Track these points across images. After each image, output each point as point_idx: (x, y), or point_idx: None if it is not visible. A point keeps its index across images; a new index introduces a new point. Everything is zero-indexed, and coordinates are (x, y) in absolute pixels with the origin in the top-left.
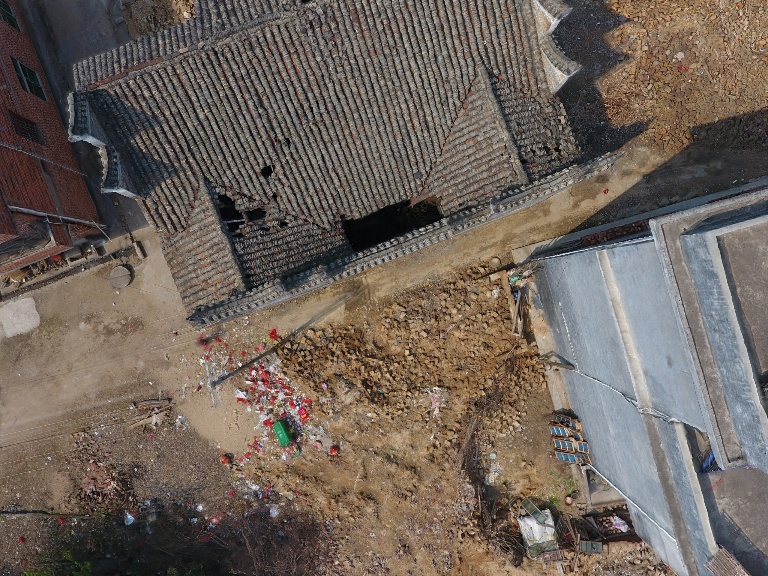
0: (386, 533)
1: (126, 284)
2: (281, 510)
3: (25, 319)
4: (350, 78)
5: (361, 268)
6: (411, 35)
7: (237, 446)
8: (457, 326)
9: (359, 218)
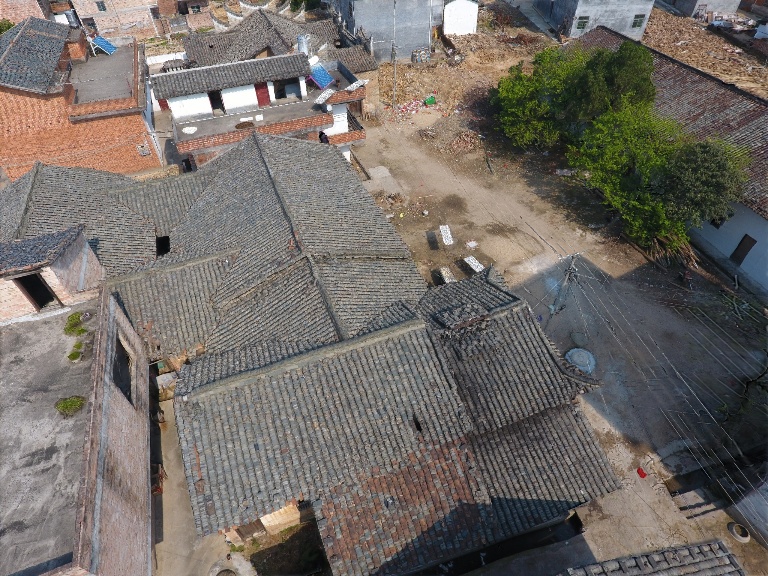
0: None
1: None
2: None
3: (380, 170)
4: None
5: None
6: None
7: None
8: None
9: None
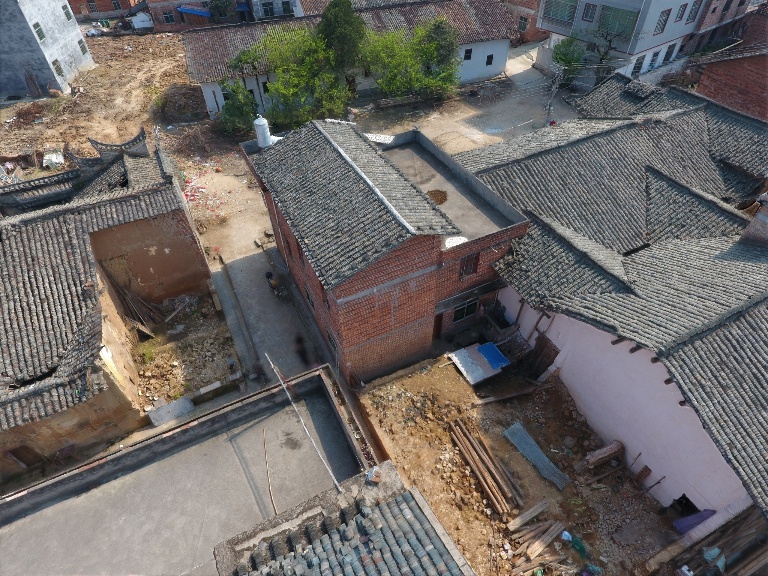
0: None
1: (269, 227)
2: None
3: None
4: None
5: None
6: None
7: None
8: None
9: None
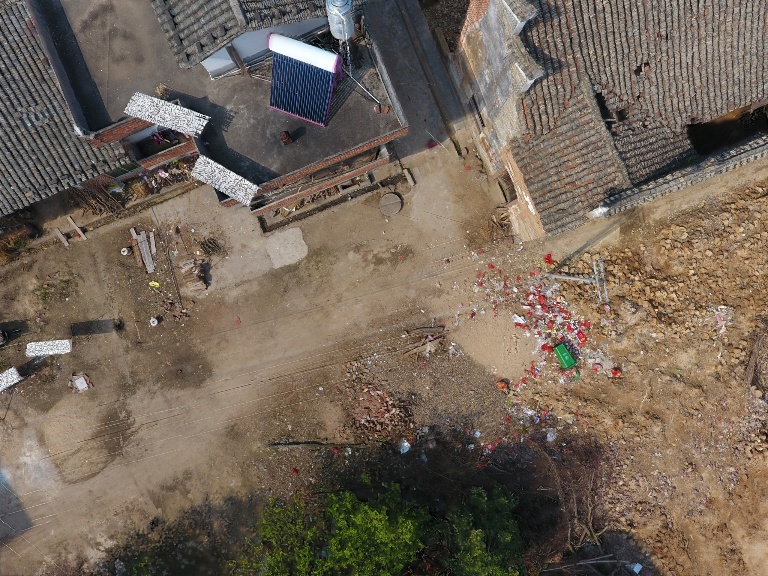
0: (672, 452)
1: (397, 211)
2: (559, 434)
3: (292, 249)
4: None
5: (734, 166)
6: None
7: (514, 371)
8: (741, 245)
9: (708, 122)
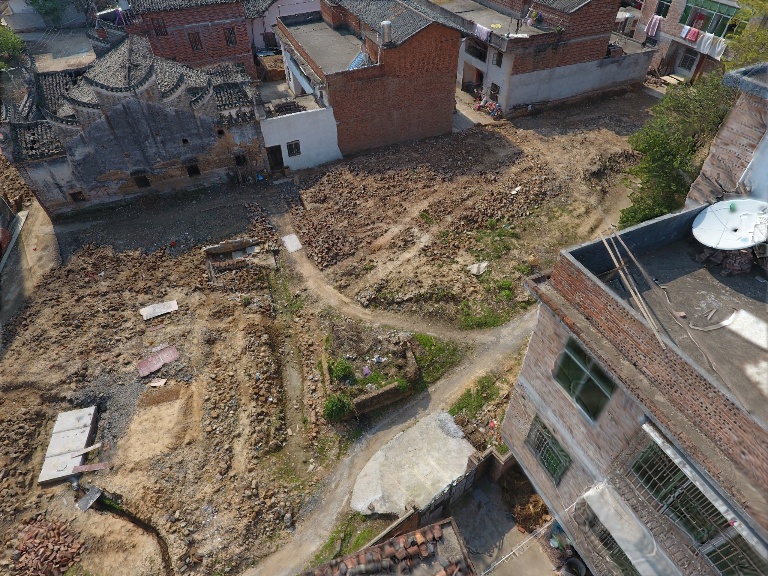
0: None
1: None
2: None
3: None
4: None
5: None
6: None
7: None
8: None
9: None
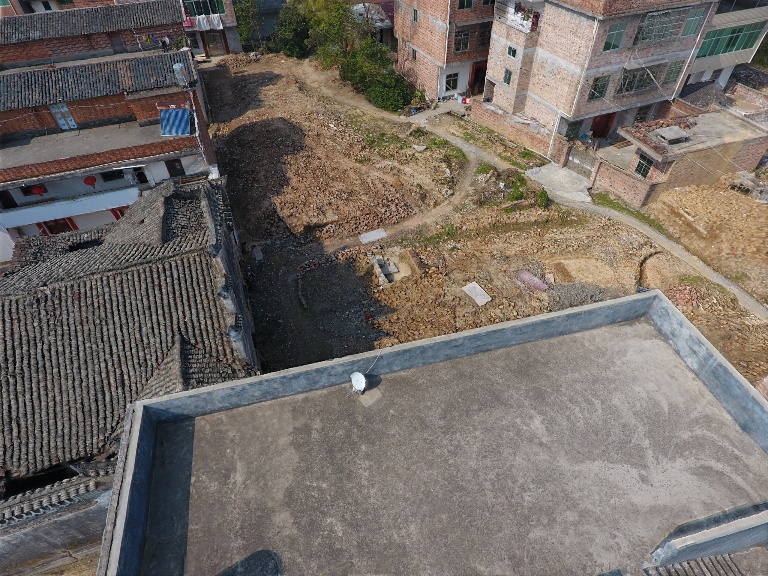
0: None
1: None
2: None
3: None
4: (59, 340)
5: None
6: (121, 311)
7: None
8: None
9: (25, 474)
